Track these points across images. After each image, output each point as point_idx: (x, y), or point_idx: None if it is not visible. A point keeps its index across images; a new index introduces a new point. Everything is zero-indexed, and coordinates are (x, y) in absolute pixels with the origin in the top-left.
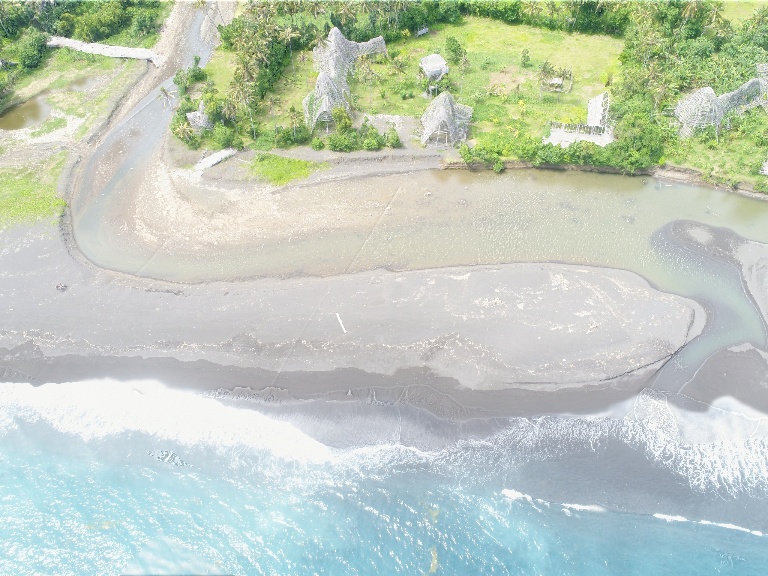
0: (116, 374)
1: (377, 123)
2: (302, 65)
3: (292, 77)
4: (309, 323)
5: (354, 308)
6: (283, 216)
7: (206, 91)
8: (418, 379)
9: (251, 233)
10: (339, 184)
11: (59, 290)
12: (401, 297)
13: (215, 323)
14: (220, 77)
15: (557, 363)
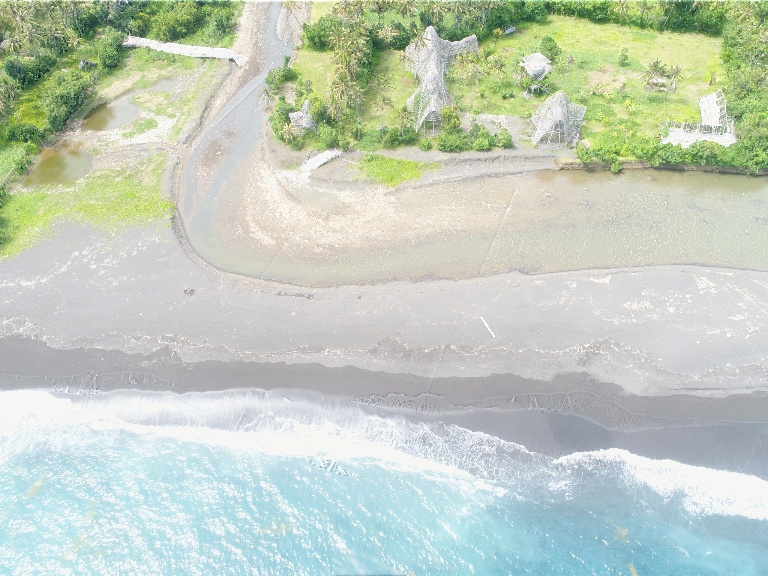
0: (261, 380)
1: (482, 123)
2: (391, 64)
3: (383, 77)
4: (455, 328)
5: (498, 312)
6: (401, 218)
7: (299, 91)
8: (579, 385)
9: (372, 235)
10: (453, 185)
11: (187, 294)
12: (545, 301)
13: (357, 328)
14: (309, 77)
15: (722, 368)
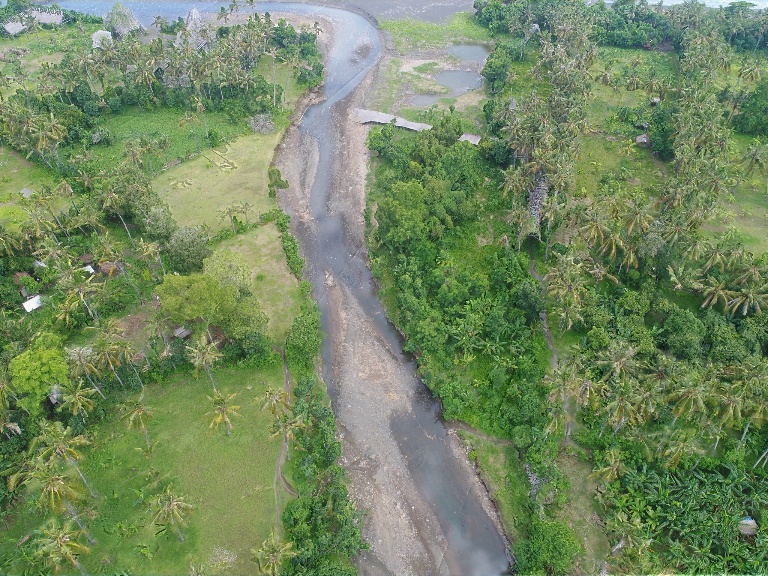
0: None
1: None
2: None
3: None
4: None
5: None
6: (247, 17)
7: None
8: None
9: None
10: None
11: None
12: None
13: None
14: None
15: None
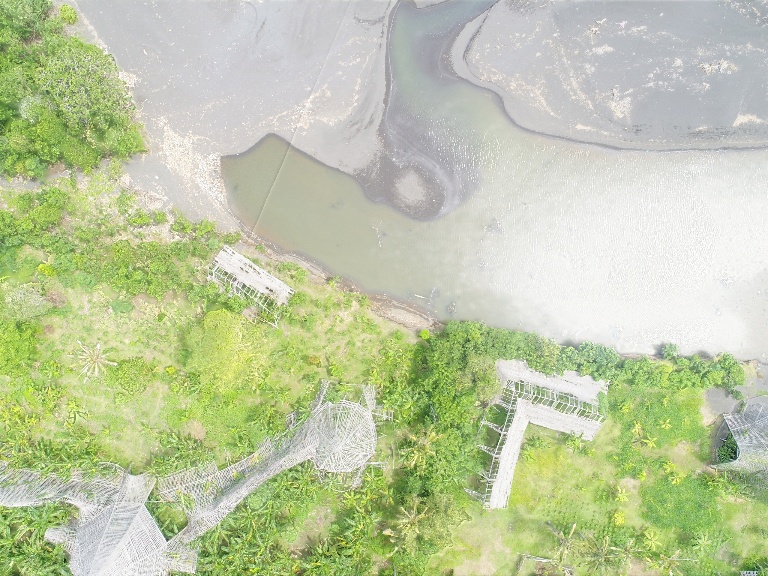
0: None
1: None
2: None
3: None
4: None
5: None
6: None
7: None
8: None
9: None
10: None
11: None
12: None
13: None
14: None
15: None
